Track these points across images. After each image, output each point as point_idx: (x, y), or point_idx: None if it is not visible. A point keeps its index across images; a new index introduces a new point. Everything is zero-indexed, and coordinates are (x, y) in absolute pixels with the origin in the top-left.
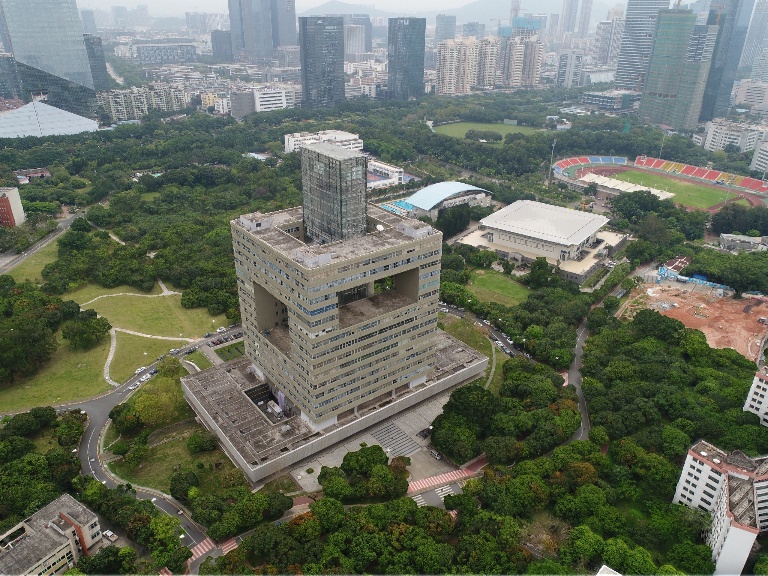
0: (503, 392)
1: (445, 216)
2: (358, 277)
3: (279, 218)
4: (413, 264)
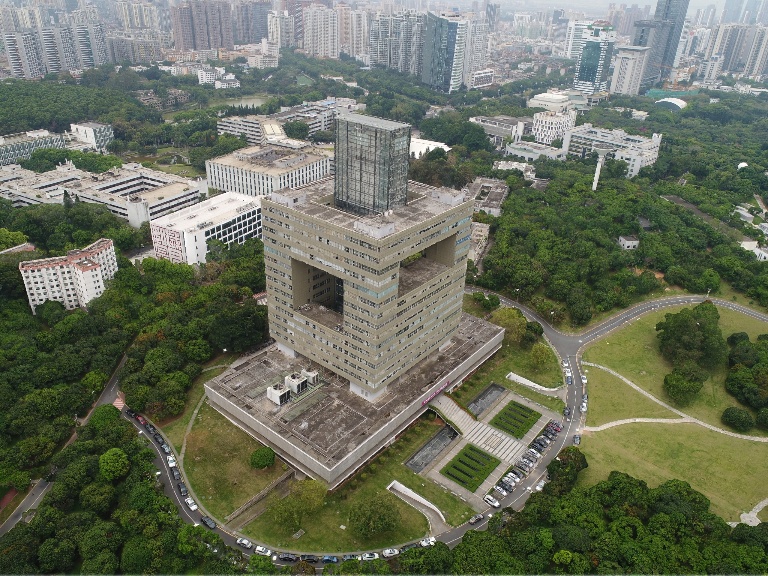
0: None
1: None
2: None
3: (436, 208)
4: None
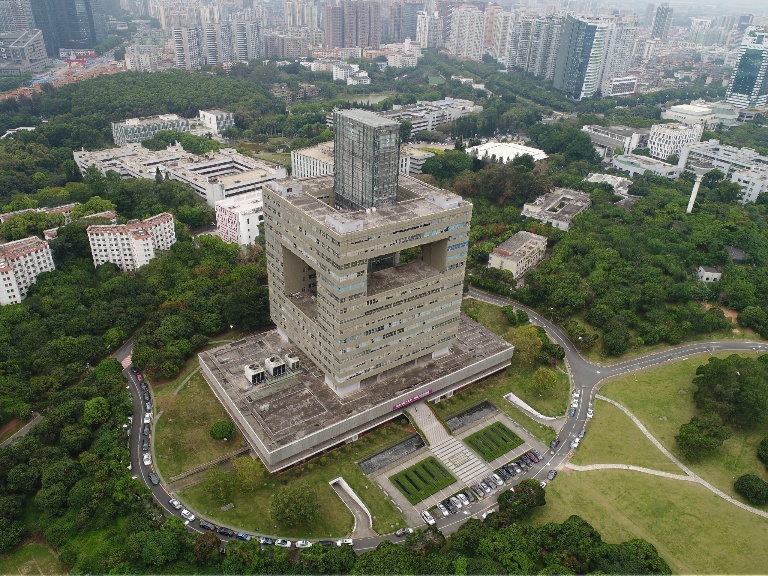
0: None
1: None
2: None
3: (425, 210)
4: None
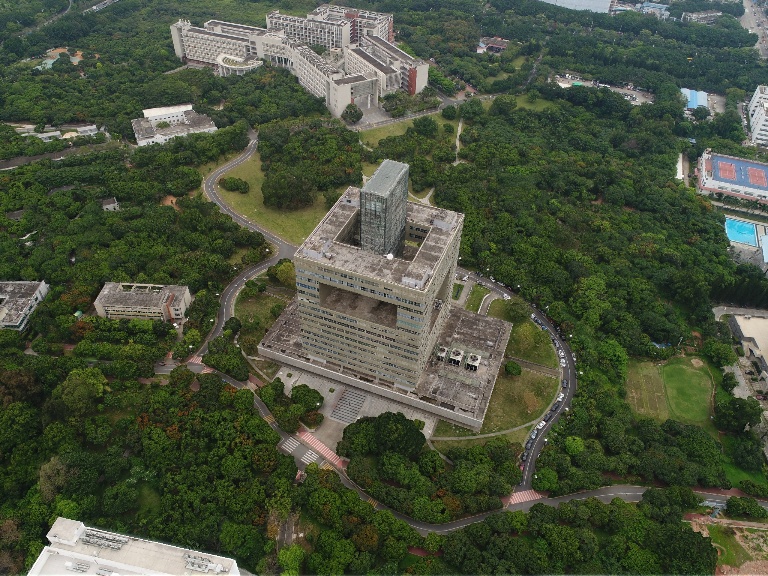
0: (450, 451)
1: (759, 281)
2: (337, 281)
3: None
4: (391, 300)
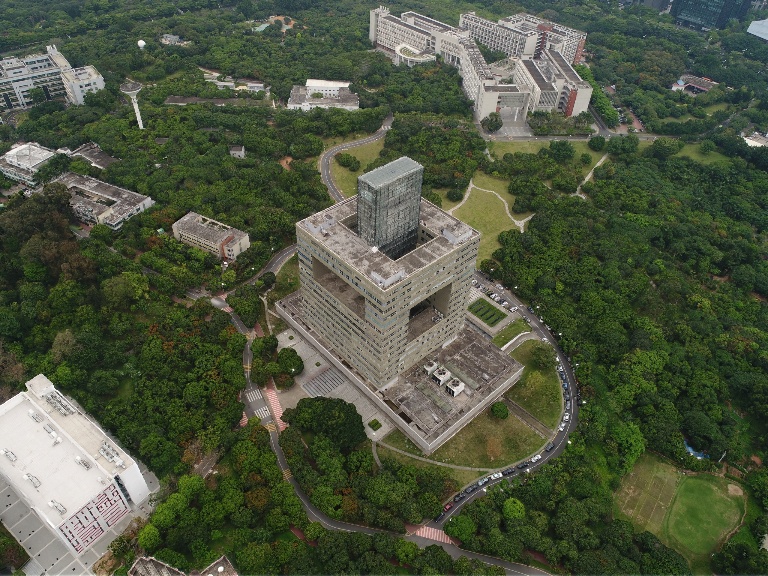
0: (385, 460)
1: None
2: None
3: None
4: (360, 290)
